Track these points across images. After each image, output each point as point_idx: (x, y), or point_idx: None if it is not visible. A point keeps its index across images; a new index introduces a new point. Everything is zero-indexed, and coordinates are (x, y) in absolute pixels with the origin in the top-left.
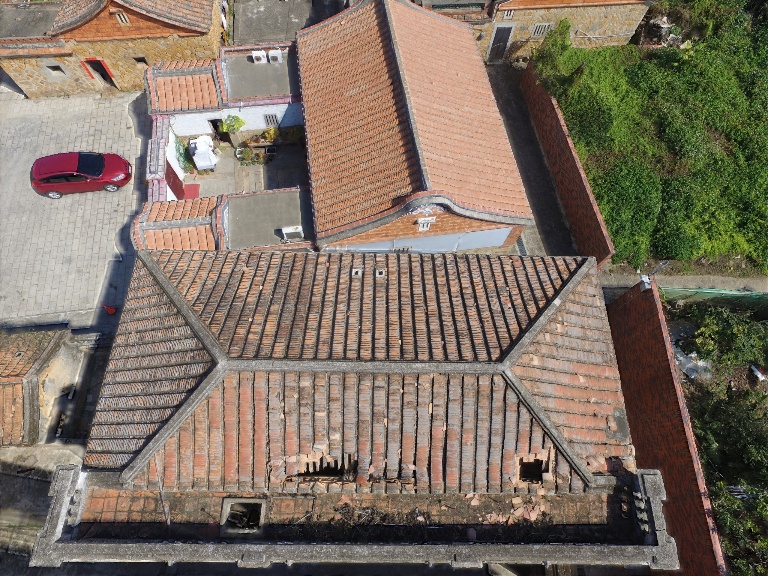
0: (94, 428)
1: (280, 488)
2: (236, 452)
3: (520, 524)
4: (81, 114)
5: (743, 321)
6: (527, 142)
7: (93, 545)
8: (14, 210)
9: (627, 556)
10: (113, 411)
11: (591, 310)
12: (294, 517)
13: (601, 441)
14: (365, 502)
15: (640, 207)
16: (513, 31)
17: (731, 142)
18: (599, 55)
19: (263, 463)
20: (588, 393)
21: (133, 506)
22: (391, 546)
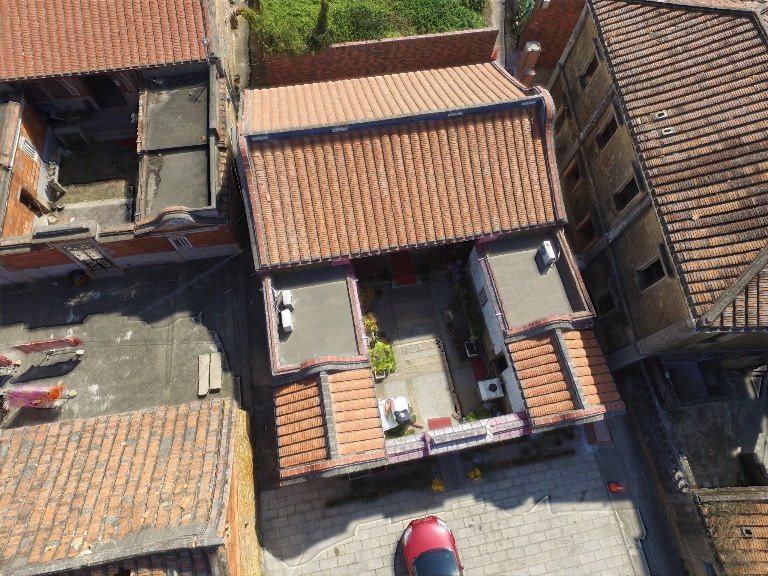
0: None
1: None
2: None
3: None
4: None
5: None
6: None
7: None
8: None
9: None
10: None
11: None
12: None
13: None
14: None
15: None
16: (225, 71)
17: None
18: (272, 6)
19: None
20: (709, 2)
21: None
22: None
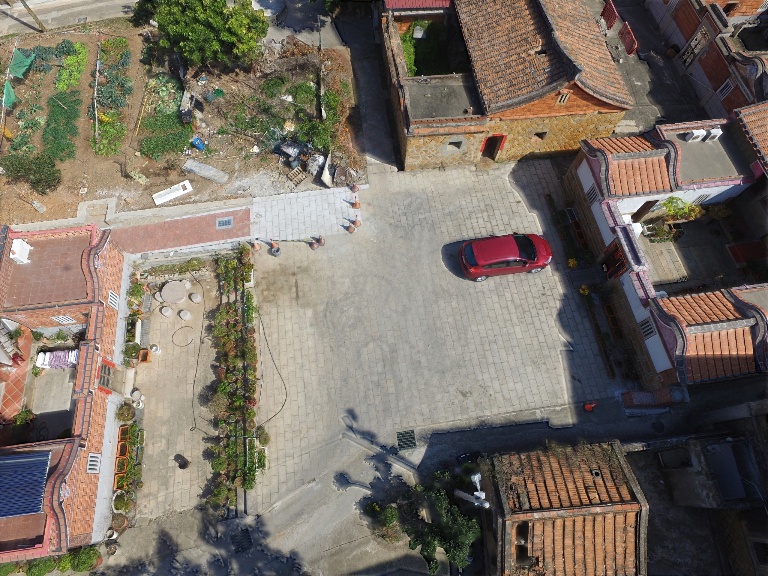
0: None
1: None
2: None
3: None
4: (464, 187)
5: None
6: None
7: None
8: (440, 294)
9: None
10: None
11: None
12: None
13: None
14: None
15: None
16: None
17: None
18: None
19: None
20: None
21: None
22: None
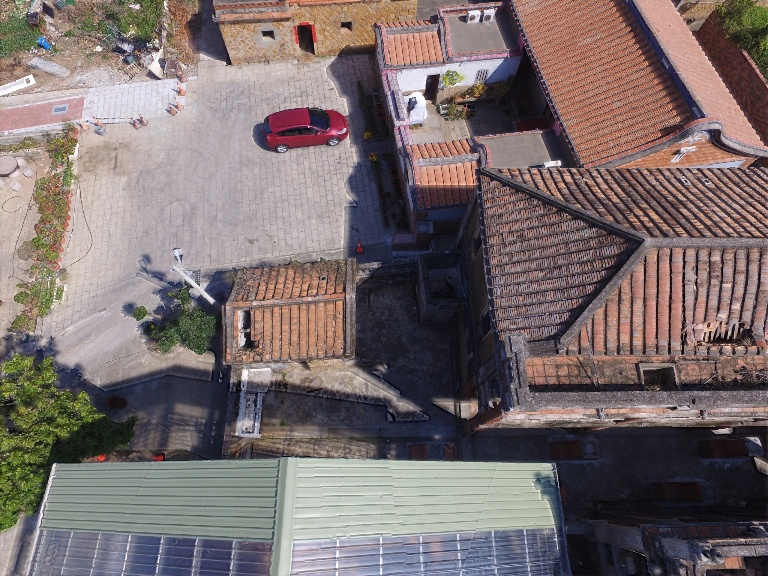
0: (499, 311)
1: (693, 351)
2: (654, 320)
3: None
4: (284, 78)
5: None
6: None
7: (565, 393)
8: (245, 164)
9: None
10: (515, 296)
11: None
12: (702, 378)
13: None
14: (759, 365)
15: None
16: None
17: None
18: None
19: (679, 329)
20: None
21: (559, 372)
22: None
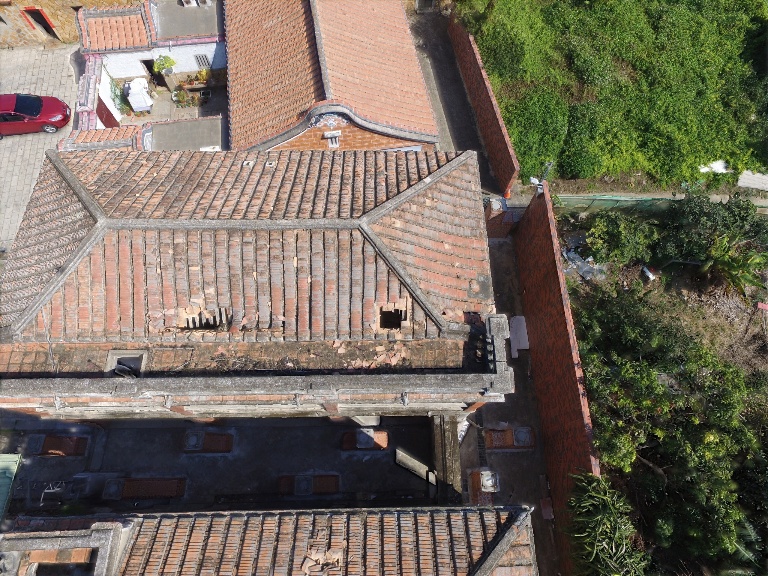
0: None
1: (159, 337)
2: (117, 305)
3: (380, 366)
4: (24, 64)
5: (630, 221)
6: (452, 82)
7: None
8: None
9: (468, 383)
10: (11, 281)
11: (464, 192)
12: (173, 365)
13: (462, 299)
14: (240, 352)
15: (547, 130)
16: None
17: (637, 71)
18: None
19: (142, 314)
20: (452, 258)
21: (25, 359)
22: (253, 378)
